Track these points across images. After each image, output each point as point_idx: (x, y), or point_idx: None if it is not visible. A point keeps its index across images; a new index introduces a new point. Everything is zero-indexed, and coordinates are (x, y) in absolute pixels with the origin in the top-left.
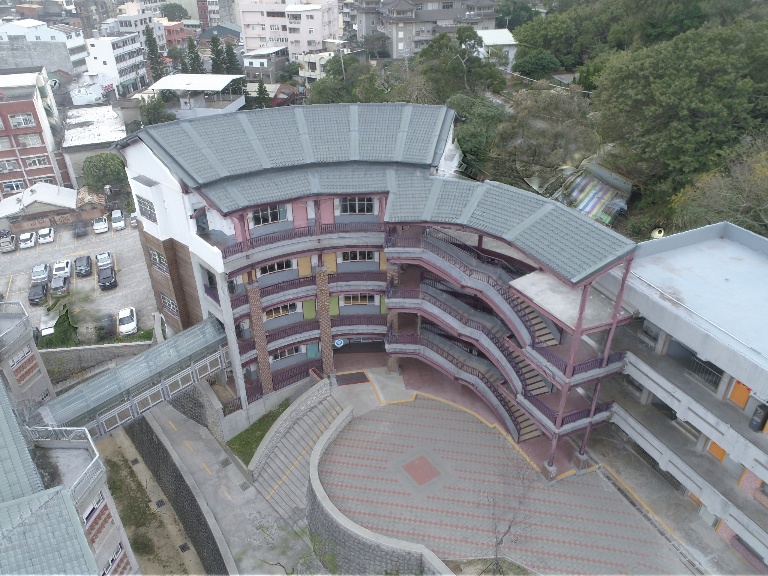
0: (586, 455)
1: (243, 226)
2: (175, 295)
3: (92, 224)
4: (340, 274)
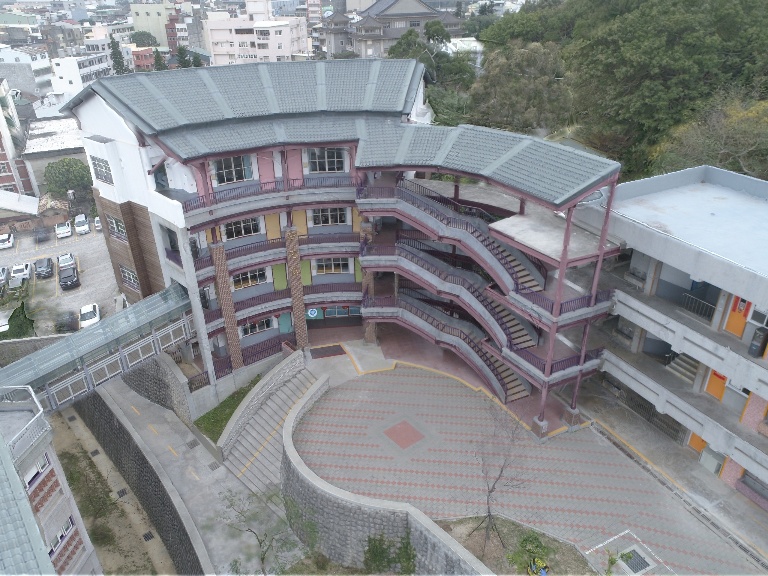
0: (578, 410)
1: (205, 178)
2: (135, 265)
3: (55, 230)
4: (311, 235)
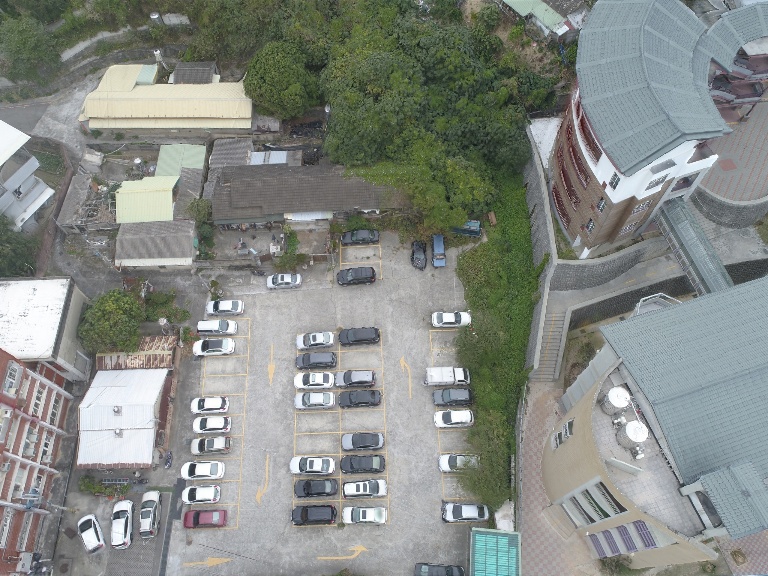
0: None
1: None
2: None
3: (198, 359)
4: None
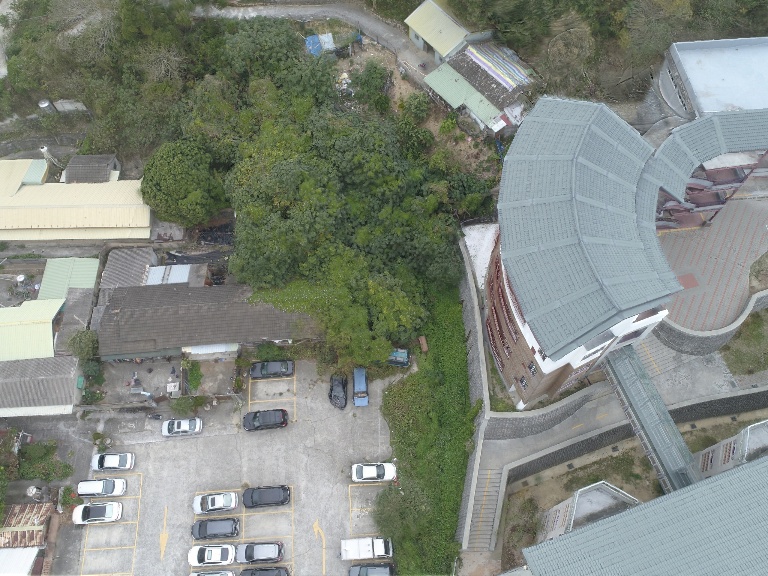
0: None
1: None
2: None
3: (78, 528)
4: None
